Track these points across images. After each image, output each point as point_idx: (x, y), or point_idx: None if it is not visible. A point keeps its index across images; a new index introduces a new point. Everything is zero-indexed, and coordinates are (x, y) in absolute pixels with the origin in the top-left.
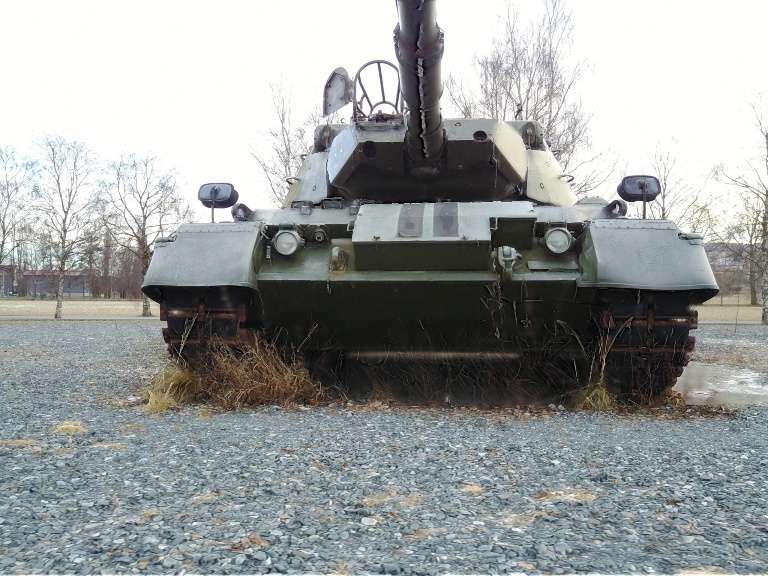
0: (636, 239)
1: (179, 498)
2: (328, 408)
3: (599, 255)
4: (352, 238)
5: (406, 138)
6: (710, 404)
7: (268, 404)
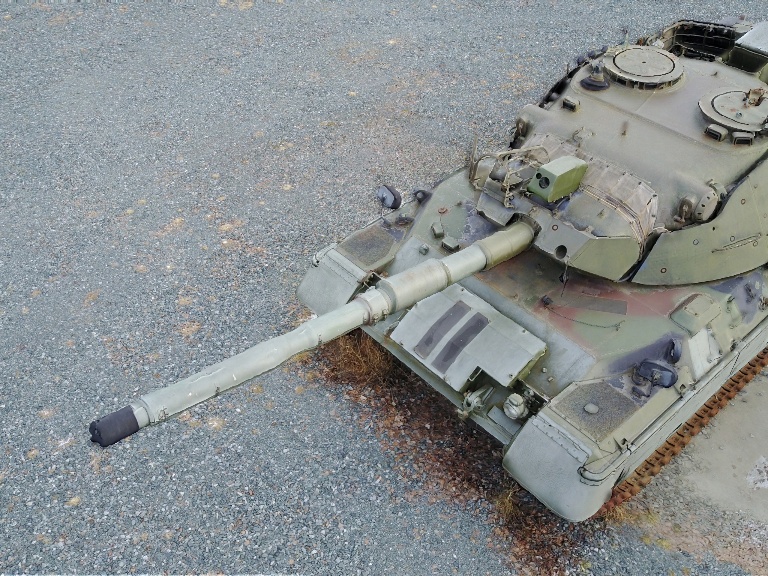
0: (546, 452)
1: (164, 526)
2: (378, 402)
3: (512, 448)
4: (392, 333)
5: (510, 221)
6: (724, 502)
7: (351, 381)
